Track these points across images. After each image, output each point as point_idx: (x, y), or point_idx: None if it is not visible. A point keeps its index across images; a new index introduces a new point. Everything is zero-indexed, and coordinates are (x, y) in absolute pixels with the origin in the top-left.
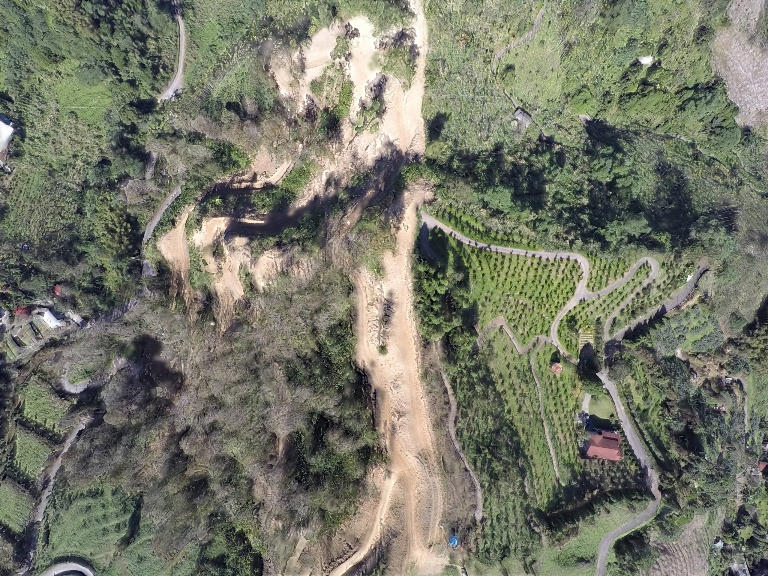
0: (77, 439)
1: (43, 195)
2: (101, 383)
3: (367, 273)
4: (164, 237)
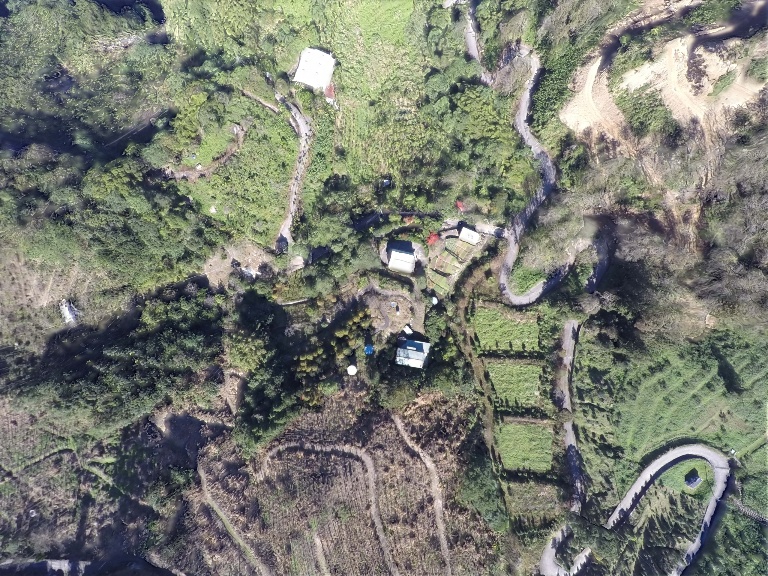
0: (601, 325)
1: (372, 129)
2: (558, 279)
3: None
4: (569, 105)
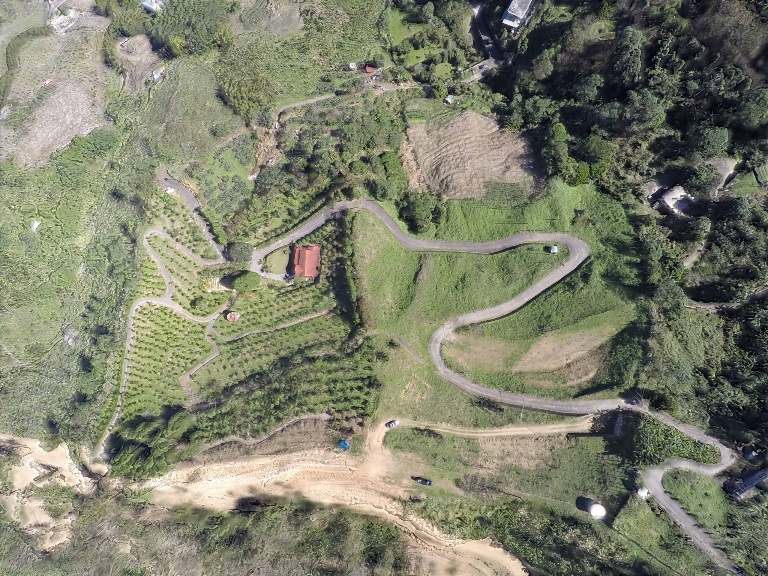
0: None
1: None
2: None
3: (135, 513)
4: None
